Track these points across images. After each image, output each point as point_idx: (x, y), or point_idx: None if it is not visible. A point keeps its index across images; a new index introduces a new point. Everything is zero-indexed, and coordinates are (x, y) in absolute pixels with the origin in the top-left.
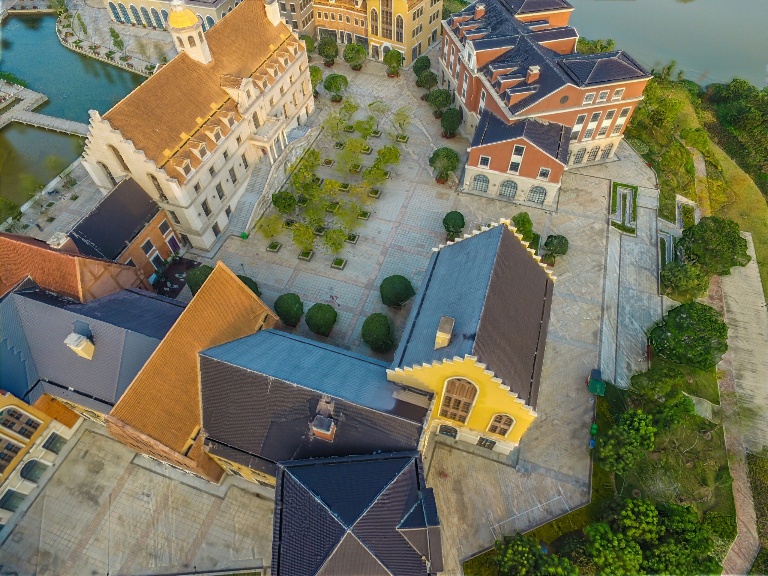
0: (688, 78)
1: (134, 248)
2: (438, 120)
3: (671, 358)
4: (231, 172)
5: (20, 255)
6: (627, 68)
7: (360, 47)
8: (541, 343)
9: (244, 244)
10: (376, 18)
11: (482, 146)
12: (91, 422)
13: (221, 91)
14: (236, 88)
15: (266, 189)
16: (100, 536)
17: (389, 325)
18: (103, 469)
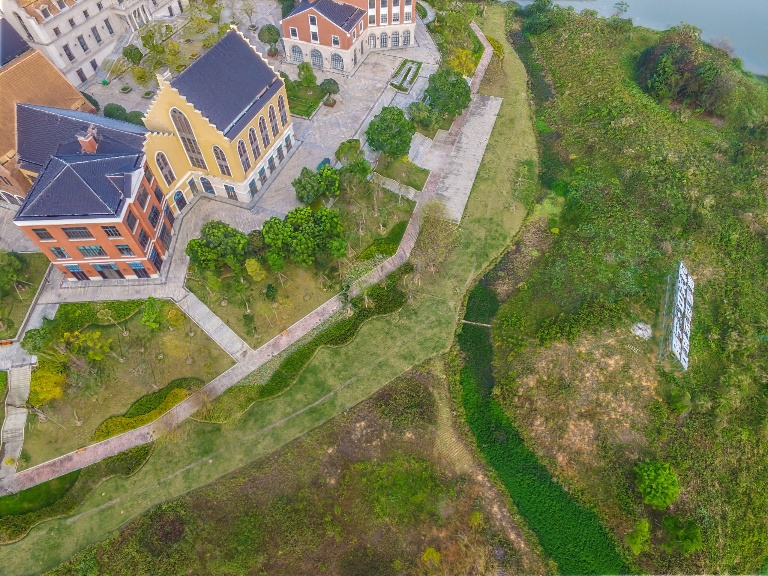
0: (514, 0)
1: None
2: None
3: (377, 149)
4: (95, 32)
5: None
6: None
7: None
8: (254, 109)
9: (104, 88)
10: None
11: (288, 18)
12: None
13: None
14: None
15: None
16: None
17: None
18: None
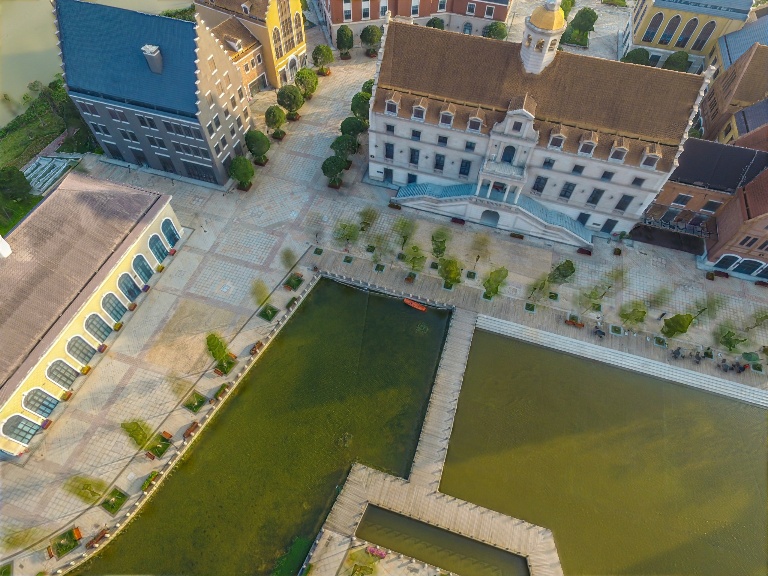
0: None
1: None
2: None
3: None
4: None
5: None
6: None
7: None
8: None
9: None
10: (278, 37)
11: None
12: None
13: None
14: None
15: None
16: None
17: None
18: None
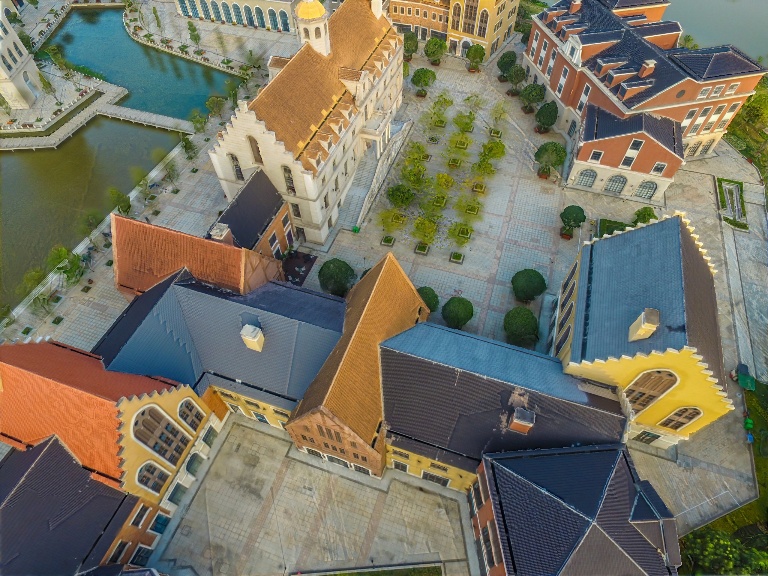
0: (765, 75)
1: (264, 241)
2: (528, 115)
3: None
4: (344, 165)
5: (178, 246)
6: (743, 63)
7: (442, 42)
8: (718, 336)
9: (357, 238)
10: (459, 13)
11: (597, 140)
12: (238, 415)
13: (339, 83)
14: (355, 80)
15: (374, 183)
16: (270, 530)
17: (536, 319)
18: (259, 463)
